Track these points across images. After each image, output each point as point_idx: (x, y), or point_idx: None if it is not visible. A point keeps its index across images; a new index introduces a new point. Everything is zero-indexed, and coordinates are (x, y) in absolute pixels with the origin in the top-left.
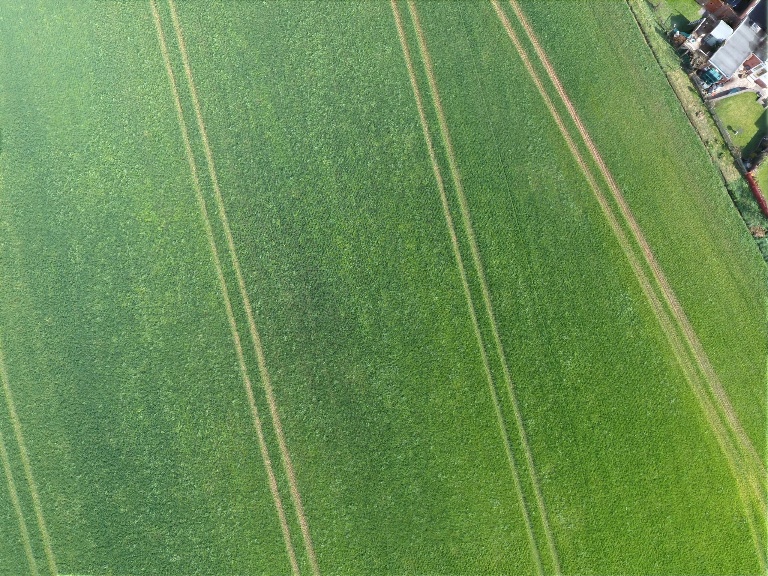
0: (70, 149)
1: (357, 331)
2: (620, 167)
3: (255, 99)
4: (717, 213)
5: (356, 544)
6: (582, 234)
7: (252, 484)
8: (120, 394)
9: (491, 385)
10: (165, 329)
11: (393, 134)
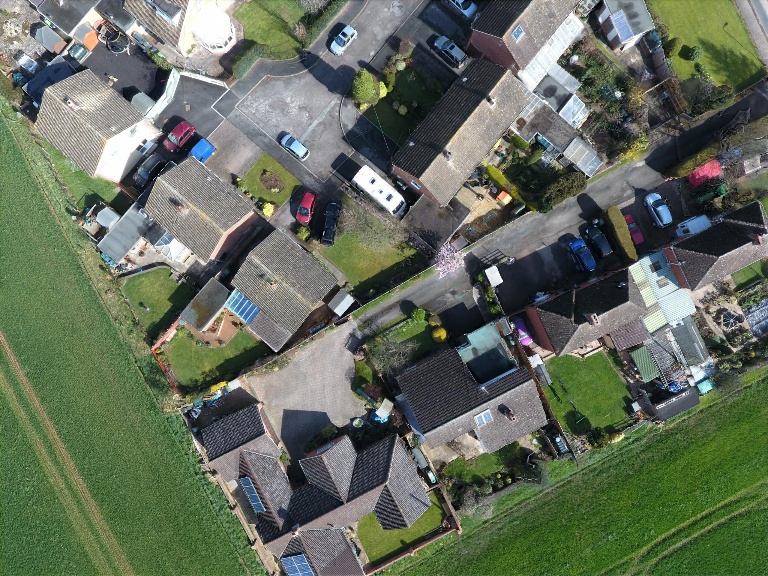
0: None
1: None
2: (24, 348)
3: None
4: (125, 389)
5: None
6: None
7: None
8: None
9: None
10: None
11: None
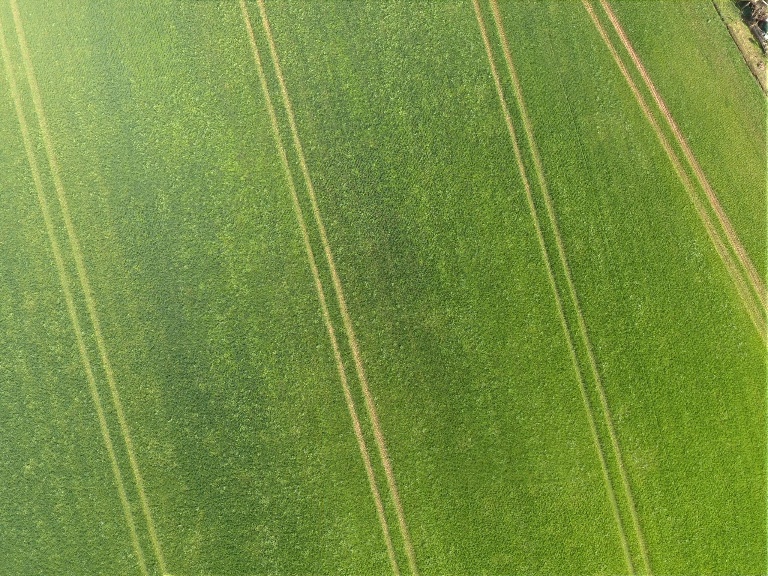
0: (154, 101)
1: (435, 277)
2: (685, 117)
3: (332, 52)
4: None
5: (438, 485)
6: (650, 182)
7: (337, 427)
8: (208, 340)
9: (565, 329)
10: (250, 276)
11: (466, 85)
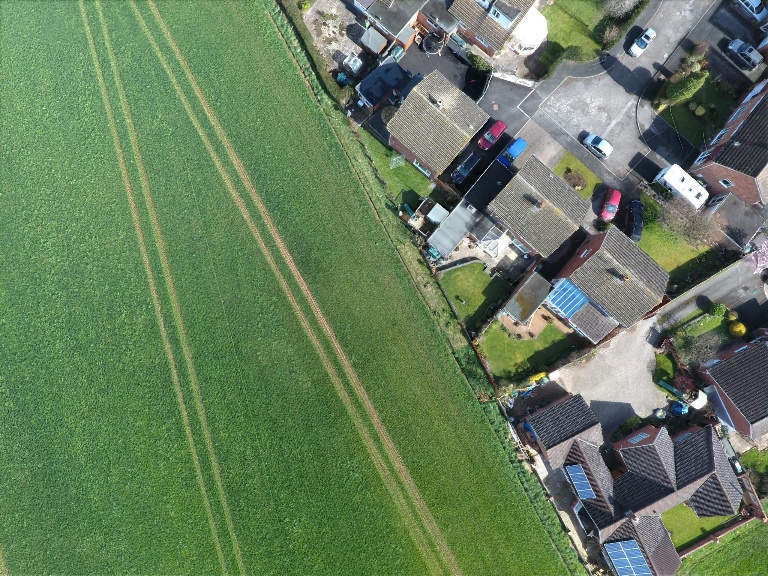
0: None
1: (87, 507)
2: (350, 339)
3: None
4: (444, 379)
5: None
6: (311, 405)
7: None
8: None
9: (220, 553)
10: None
11: (125, 316)
